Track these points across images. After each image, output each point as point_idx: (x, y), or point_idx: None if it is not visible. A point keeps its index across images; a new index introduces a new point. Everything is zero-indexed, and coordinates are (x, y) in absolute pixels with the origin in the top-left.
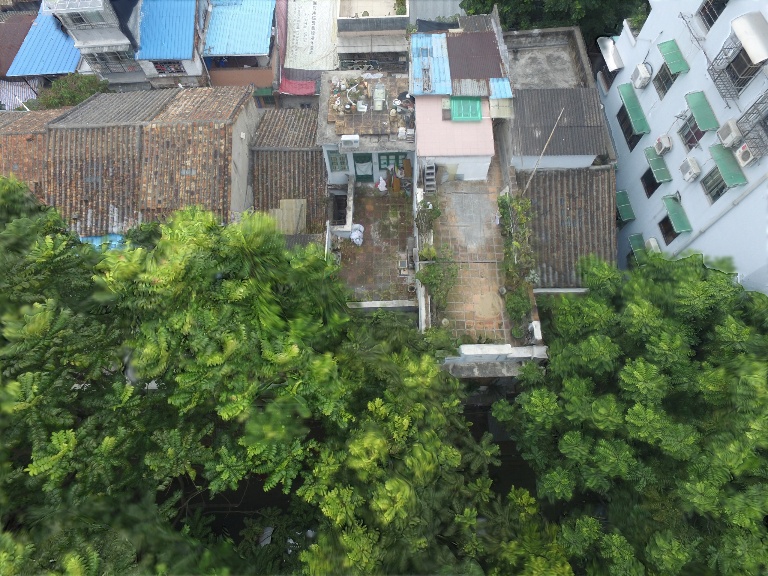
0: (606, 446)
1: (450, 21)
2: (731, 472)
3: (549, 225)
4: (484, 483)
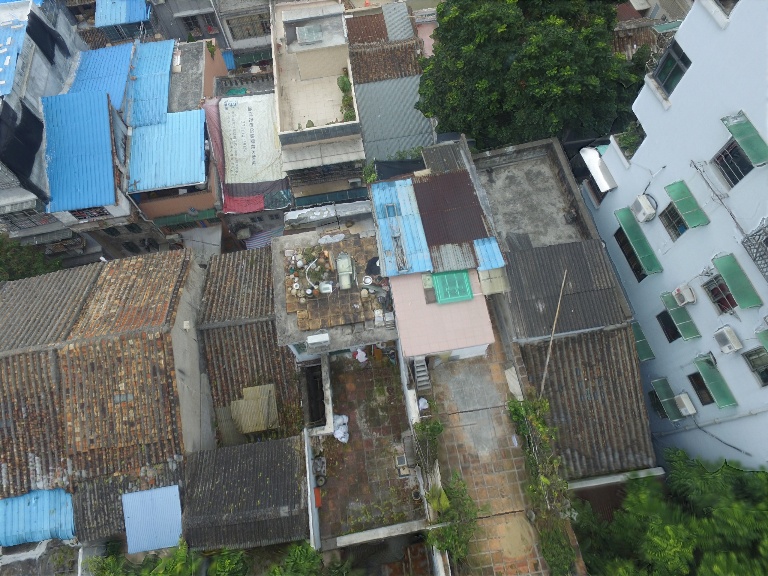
0: None
1: (412, 154)
2: None
3: (567, 402)
4: None
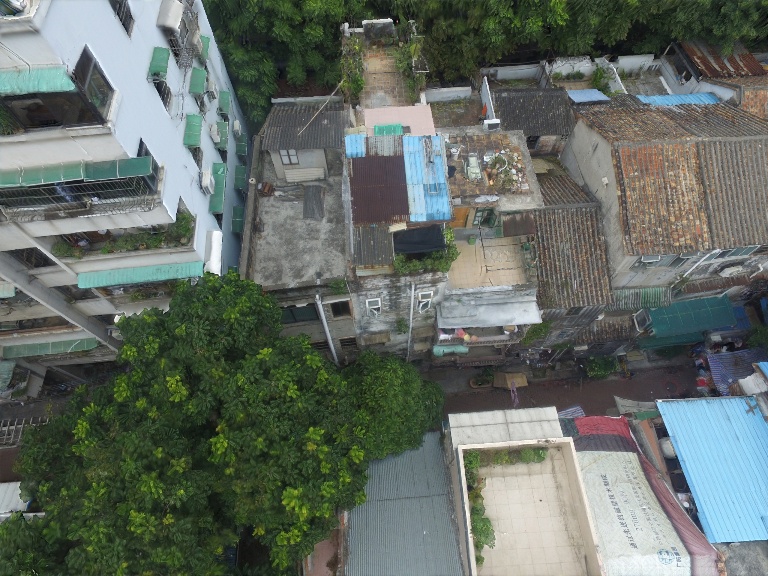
0: None
1: (403, 268)
2: None
3: None
4: None
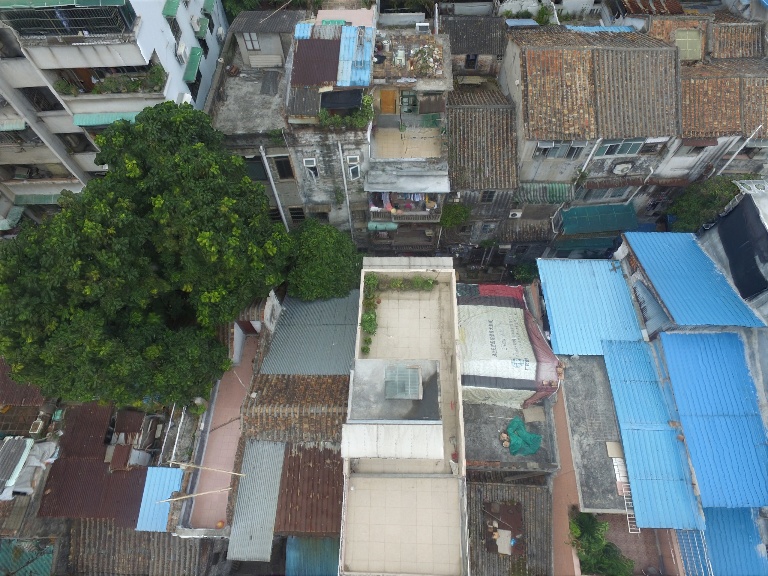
0: None
1: None
2: None
3: None
4: None
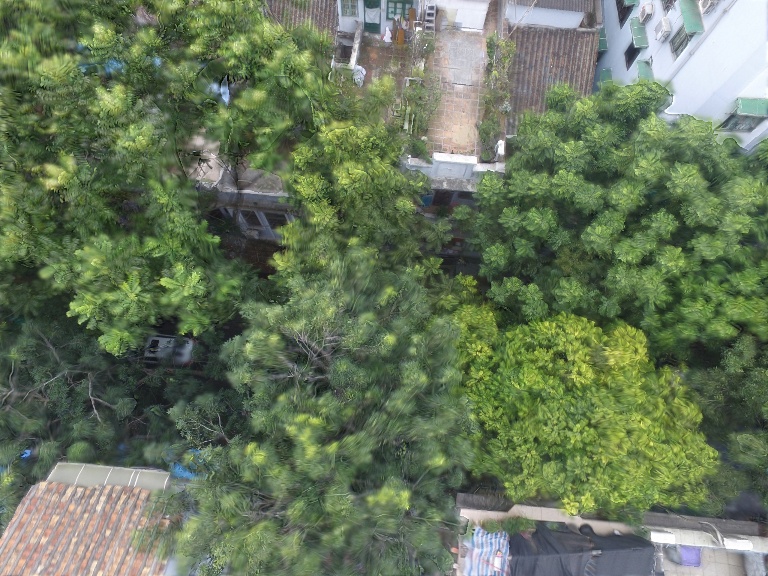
0: (535, 212)
1: None
2: (626, 226)
3: (532, 79)
4: (436, 263)
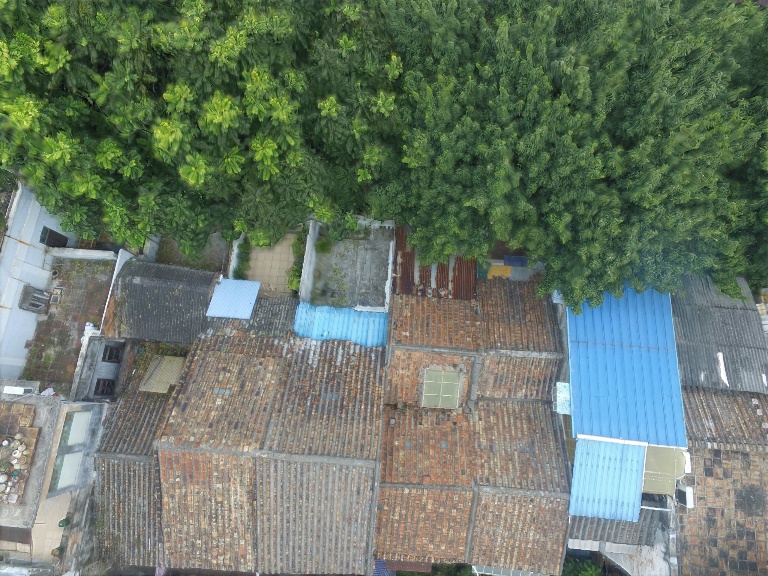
0: None
1: None
2: None
3: None
4: None
